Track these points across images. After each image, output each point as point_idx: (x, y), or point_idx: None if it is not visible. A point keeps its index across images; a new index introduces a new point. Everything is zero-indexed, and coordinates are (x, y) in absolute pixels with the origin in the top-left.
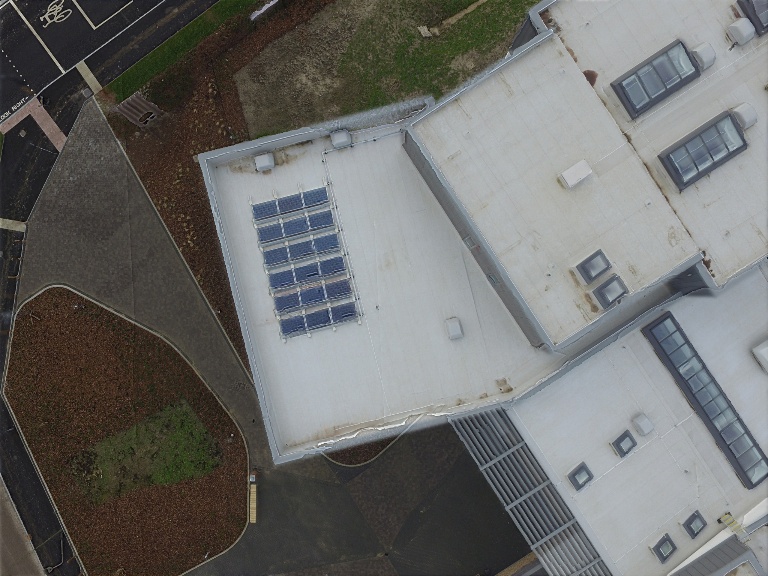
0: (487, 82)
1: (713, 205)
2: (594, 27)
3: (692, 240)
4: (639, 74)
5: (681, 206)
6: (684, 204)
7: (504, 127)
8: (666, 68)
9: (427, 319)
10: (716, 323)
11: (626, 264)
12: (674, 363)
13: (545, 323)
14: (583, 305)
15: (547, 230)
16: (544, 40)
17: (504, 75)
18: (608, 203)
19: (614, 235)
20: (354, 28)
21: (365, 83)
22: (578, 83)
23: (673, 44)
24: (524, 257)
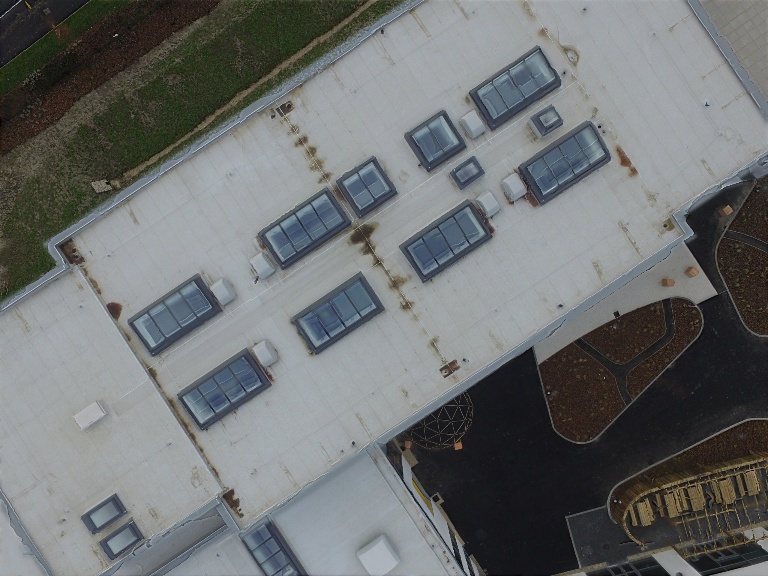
0: (2, 318)
1: (240, 443)
2: (117, 258)
3: (216, 480)
4: (151, 313)
5: (208, 443)
6: (211, 441)
7: (20, 365)
8: (181, 306)
9: (5, 533)
10: (322, 524)
11: (146, 507)
12: (266, 572)
13: (60, 570)
14: (101, 550)
15: (63, 473)
16: (61, 274)
17: (20, 310)
18: (128, 443)
19: (133, 477)
20: (20, 187)
21: (33, 243)
22: (98, 318)
23: (189, 280)
24: (39, 501)
